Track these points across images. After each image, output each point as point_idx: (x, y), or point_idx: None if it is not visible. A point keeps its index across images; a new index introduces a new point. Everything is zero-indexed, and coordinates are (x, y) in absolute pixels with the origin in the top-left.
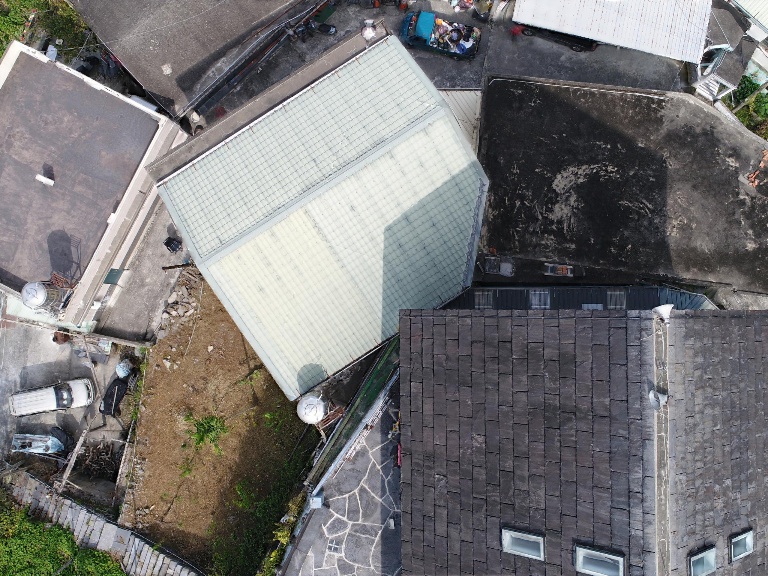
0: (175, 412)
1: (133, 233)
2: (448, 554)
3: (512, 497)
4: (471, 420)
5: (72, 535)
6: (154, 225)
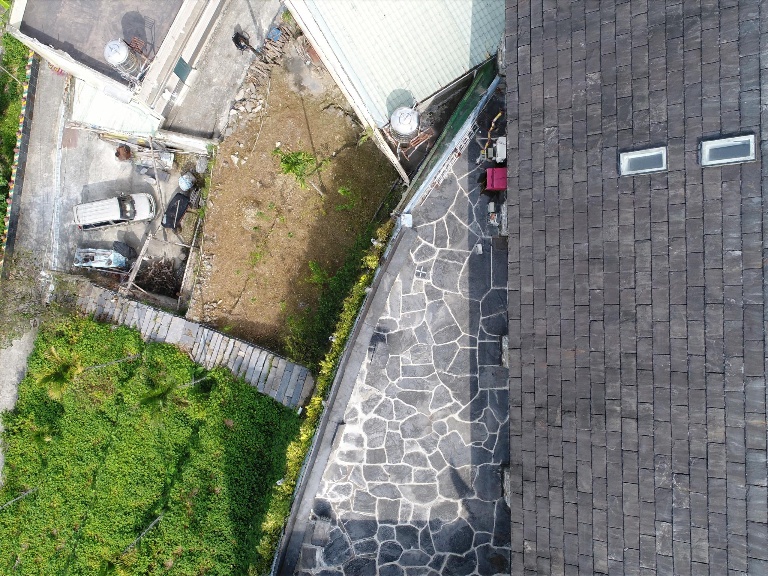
0: (243, 206)
1: (203, 26)
2: (560, 201)
3: (630, 121)
4: (585, 61)
5: (139, 333)
6: (221, 26)
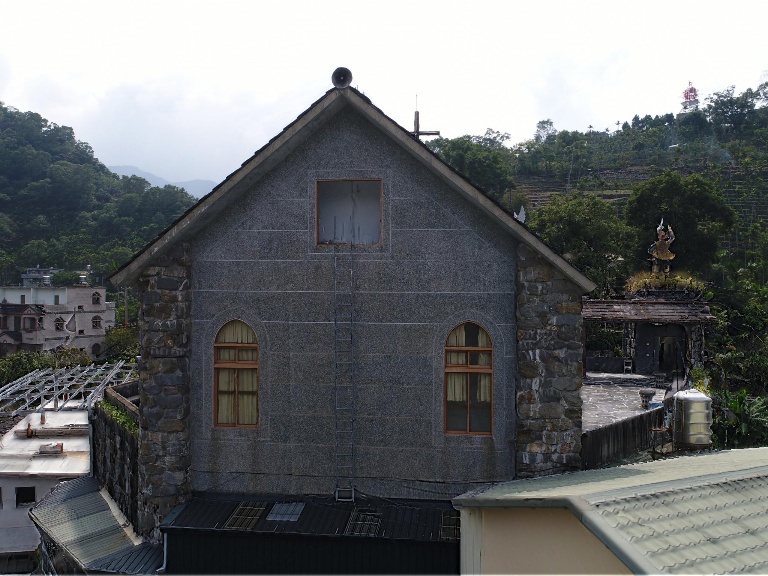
0: None
1: None
2: None
3: None
4: None
5: None
6: None
